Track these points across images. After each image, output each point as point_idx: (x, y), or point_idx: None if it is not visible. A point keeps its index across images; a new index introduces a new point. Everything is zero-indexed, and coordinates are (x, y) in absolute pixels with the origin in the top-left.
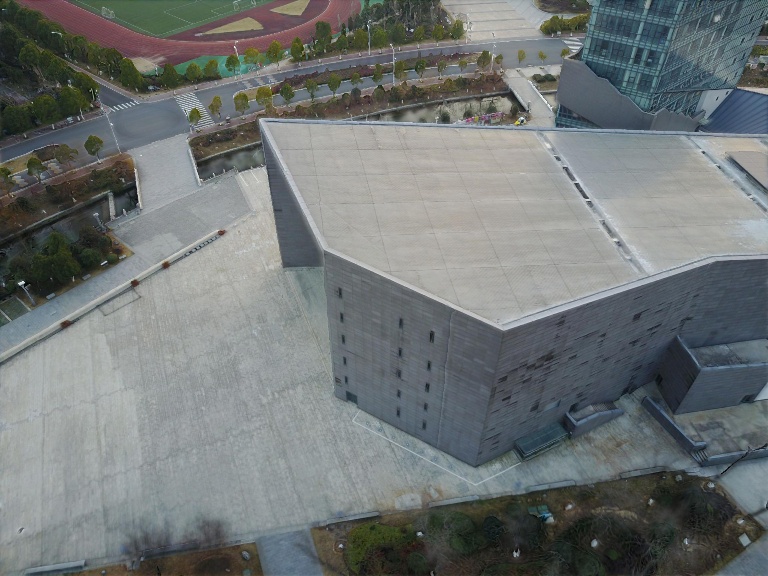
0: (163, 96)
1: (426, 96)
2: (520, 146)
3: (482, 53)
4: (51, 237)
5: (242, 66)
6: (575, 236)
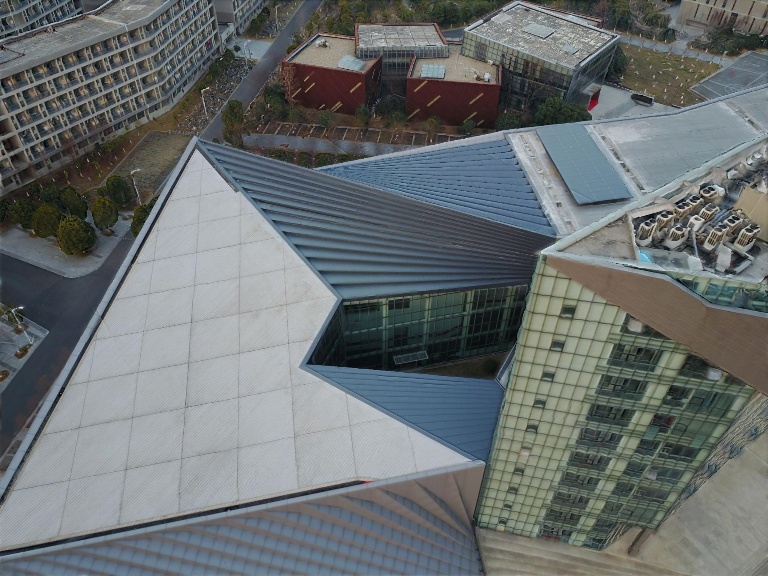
0: None
1: None
2: None
3: None
4: None
5: None
6: None
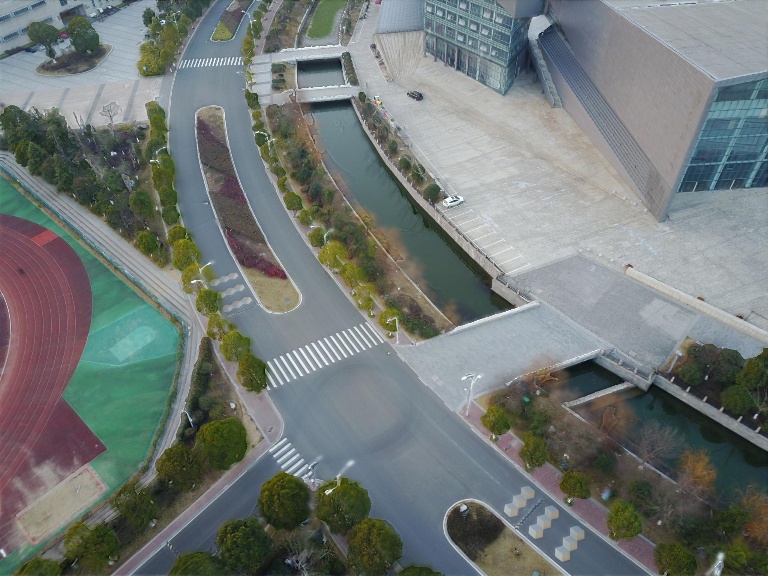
0: (260, 408)
1: (308, 151)
2: (647, 13)
3: (253, 95)
4: (762, 364)
5: (139, 331)
6: (745, 6)
